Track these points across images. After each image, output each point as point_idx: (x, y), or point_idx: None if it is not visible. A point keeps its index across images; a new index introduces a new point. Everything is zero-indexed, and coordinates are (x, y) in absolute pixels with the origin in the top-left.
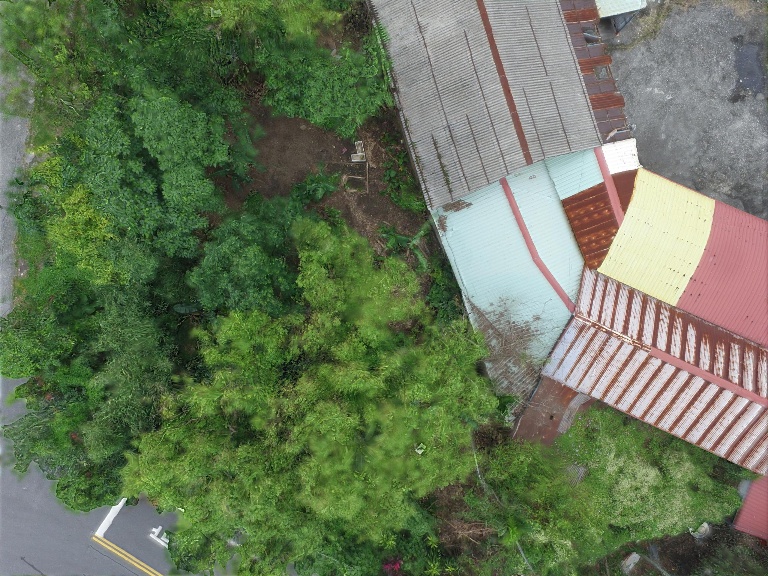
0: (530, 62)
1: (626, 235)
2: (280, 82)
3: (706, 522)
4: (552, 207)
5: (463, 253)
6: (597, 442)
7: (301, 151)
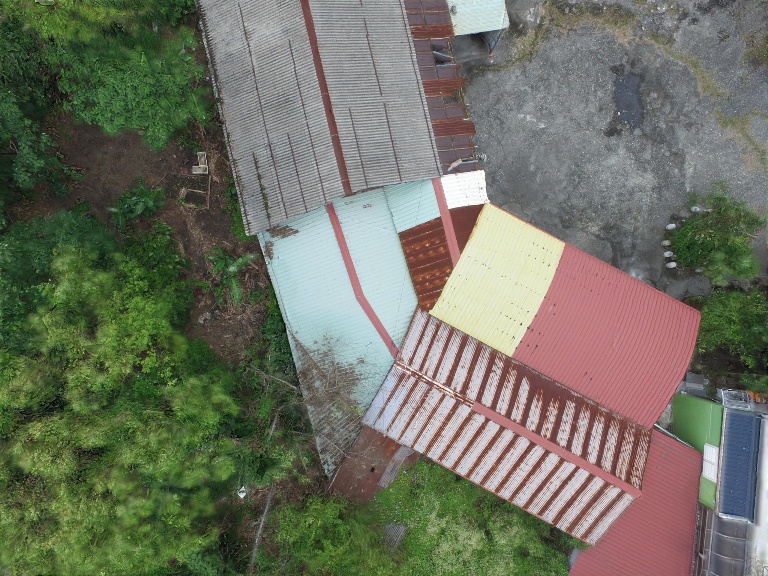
0: (362, 80)
1: (461, 276)
2: (74, 84)
3: None
4: (387, 240)
5: (288, 284)
6: (418, 499)
7: (137, 159)
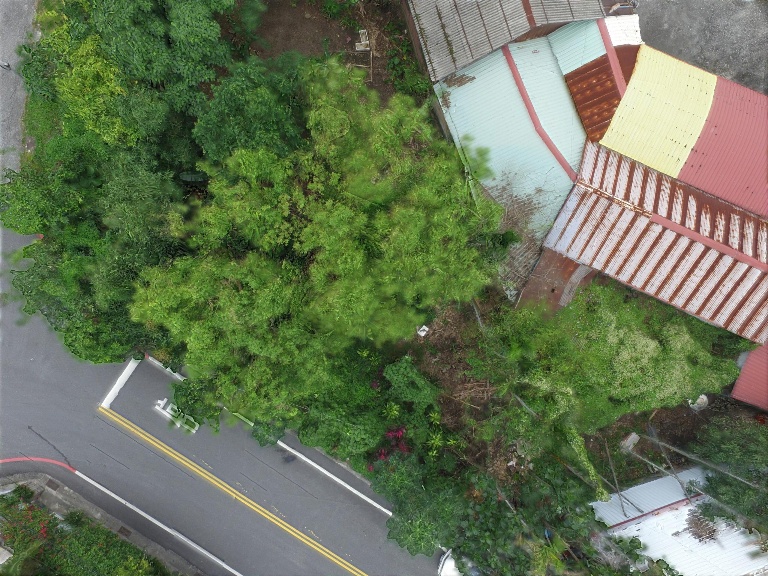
0: None
1: (628, 106)
2: None
3: (705, 395)
4: (555, 82)
5: (466, 128)
6: (598, 313)
7: (306, 39)
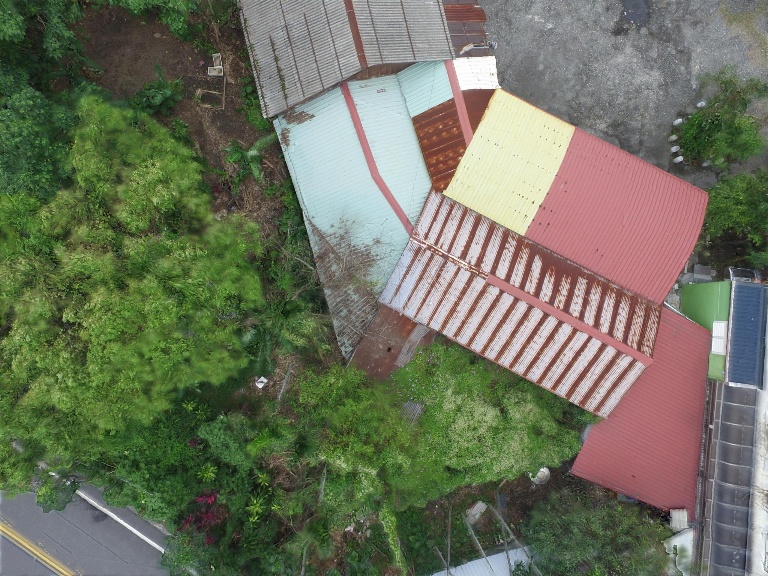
0: None
1: (474, 156)
2: None
3: (547, 468)
4: (401, 124)
5: (305, 169)
6: (434, 377)
7: (154, 60)
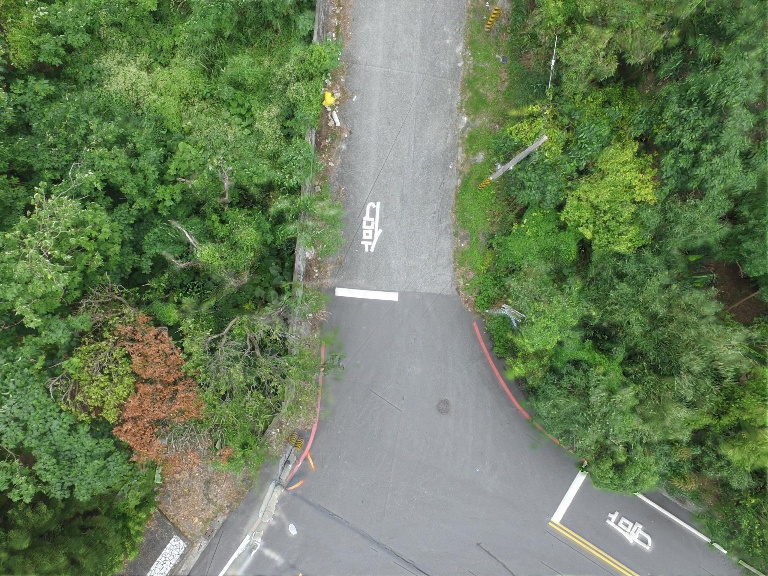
0: None
1: None
2: None
3: None
4: None
5: None
6: None
7: None
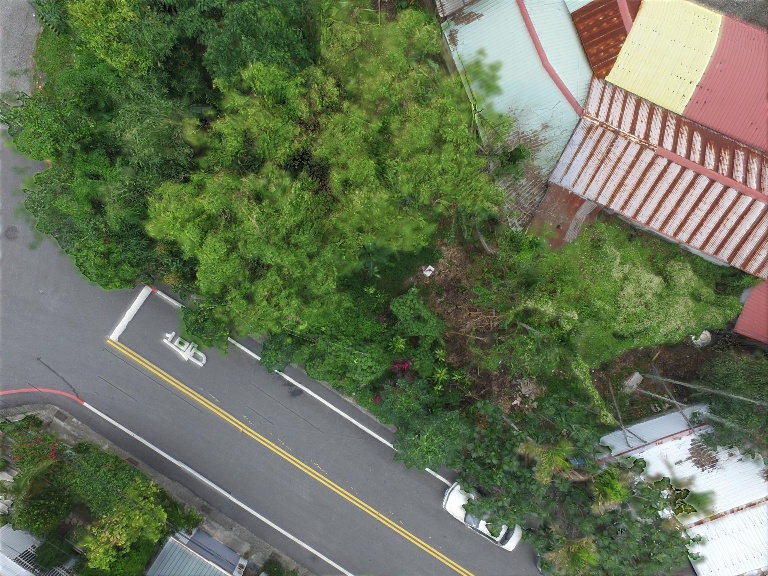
0: None
1: (634, 43)
2: None
3: (708, 331)
4: (562, 20)
5: (473, 66)
6: (603, 249)
7: None
